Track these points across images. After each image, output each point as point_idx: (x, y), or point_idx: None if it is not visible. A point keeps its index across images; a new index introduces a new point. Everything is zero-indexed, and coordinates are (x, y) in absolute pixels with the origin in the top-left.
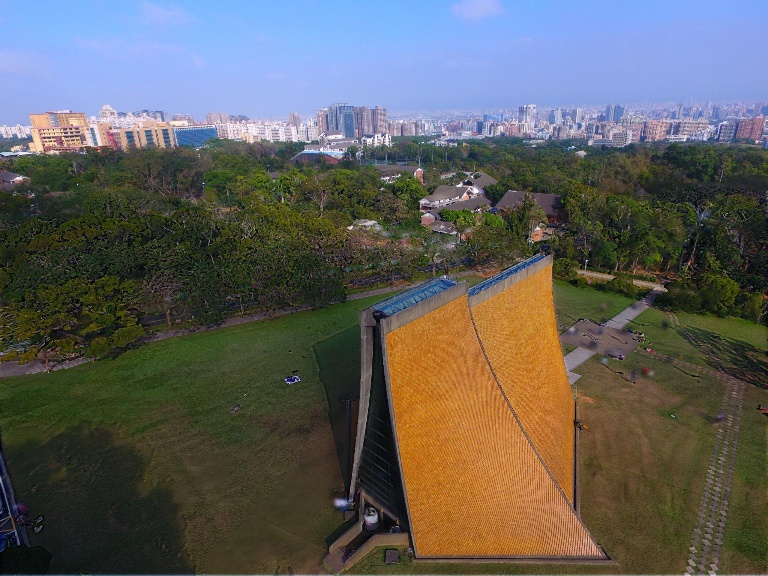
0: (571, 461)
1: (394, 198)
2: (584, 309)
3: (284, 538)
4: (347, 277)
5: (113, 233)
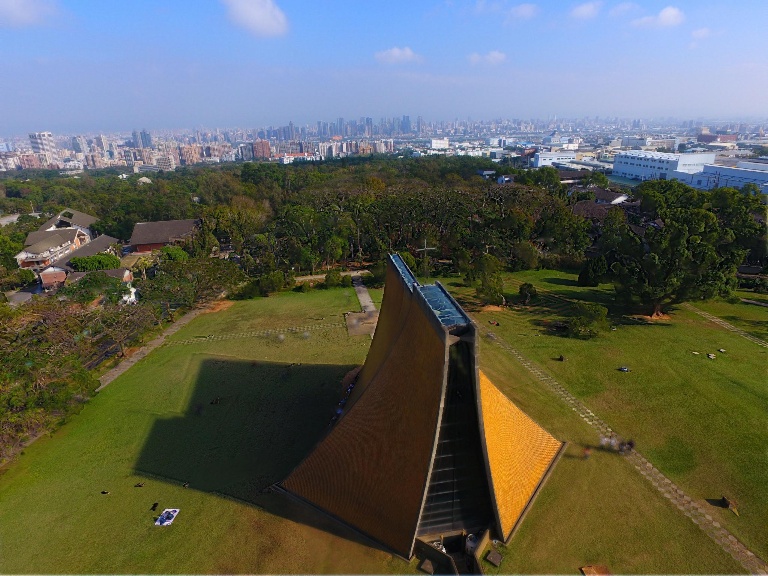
0: None
1: None
2: (335, 306)
3: None
4: None
5: None
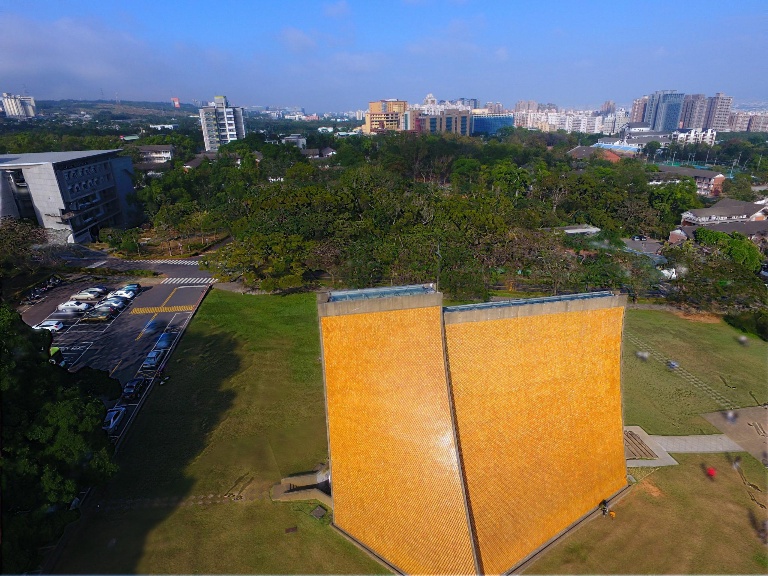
0: (550, 534)
1: (645, 206)
2: None
3: (268, 458)
4: (498, 278)
5: (316, 203)
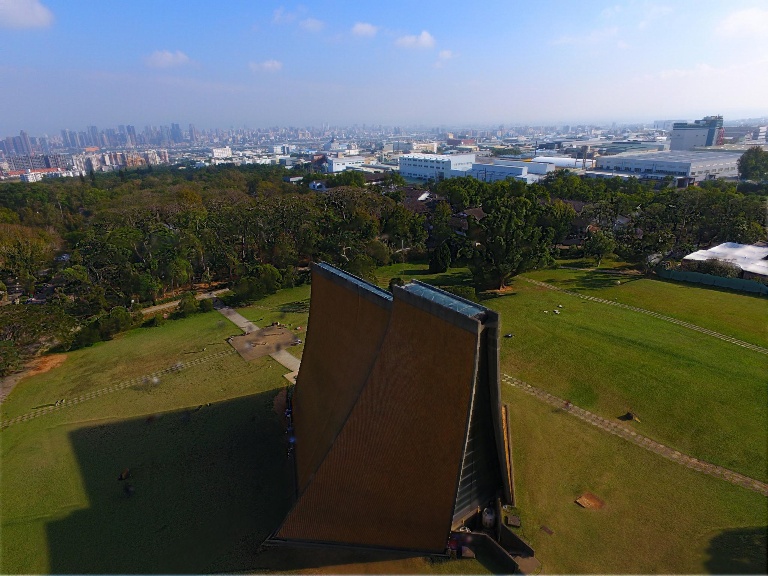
0: None
1: None
2: (209, 334)
3: None
4: None
5: None
